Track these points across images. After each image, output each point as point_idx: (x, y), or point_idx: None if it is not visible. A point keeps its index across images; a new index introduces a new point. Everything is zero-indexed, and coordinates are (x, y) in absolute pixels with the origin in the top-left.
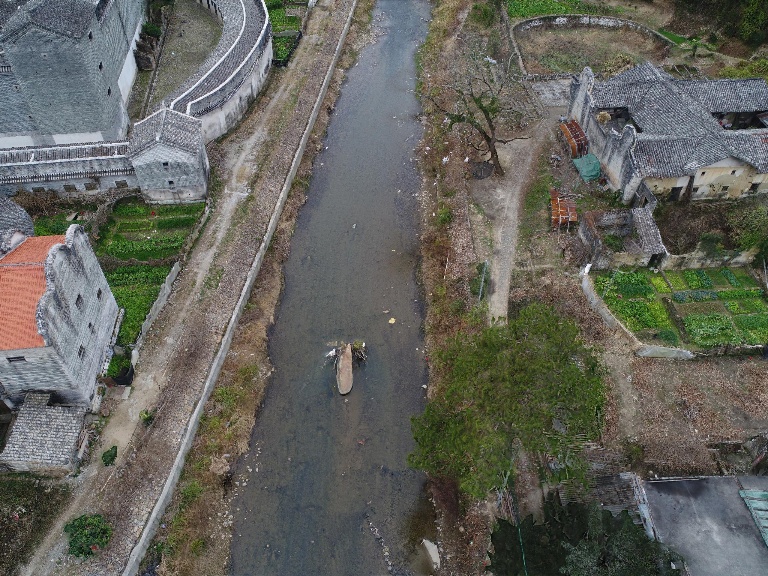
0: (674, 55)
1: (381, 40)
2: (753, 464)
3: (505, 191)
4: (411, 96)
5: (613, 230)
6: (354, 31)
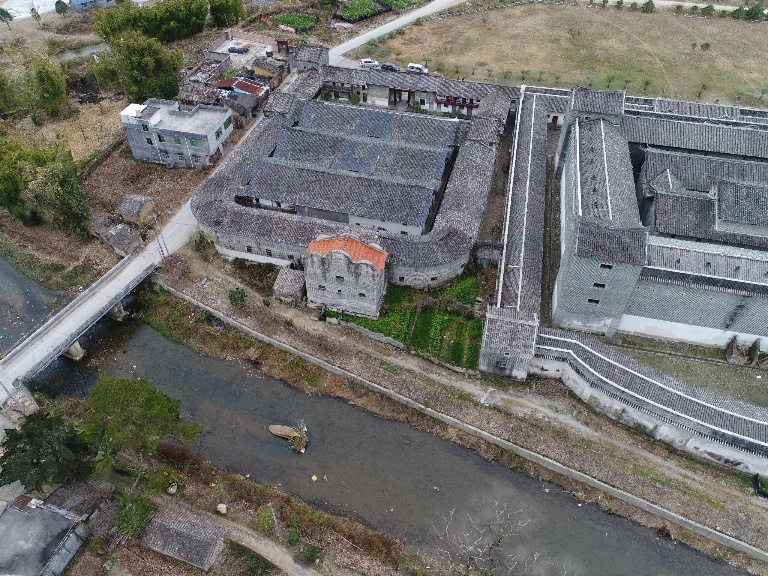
0: None
1: None
2: None
3: None
4: None
5: None
6: None
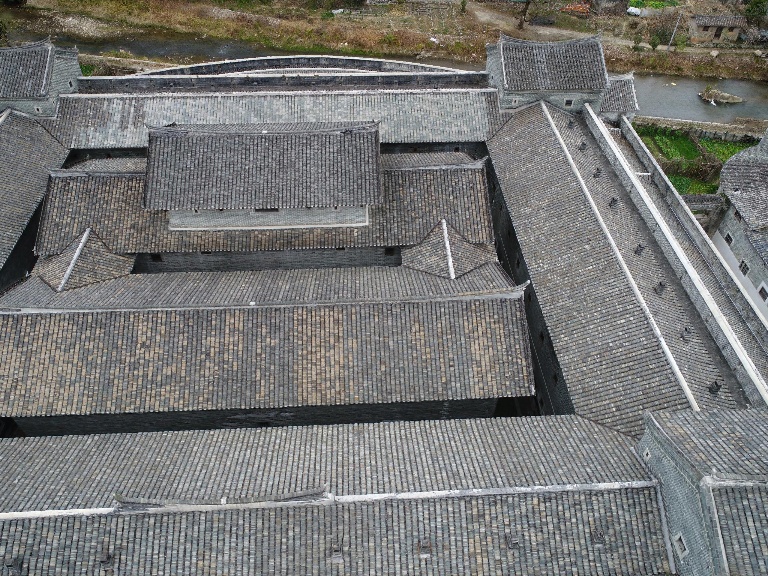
0: None
1: None
2: (738, 4)
3: (540, 30)
4: None
5: None
6: None
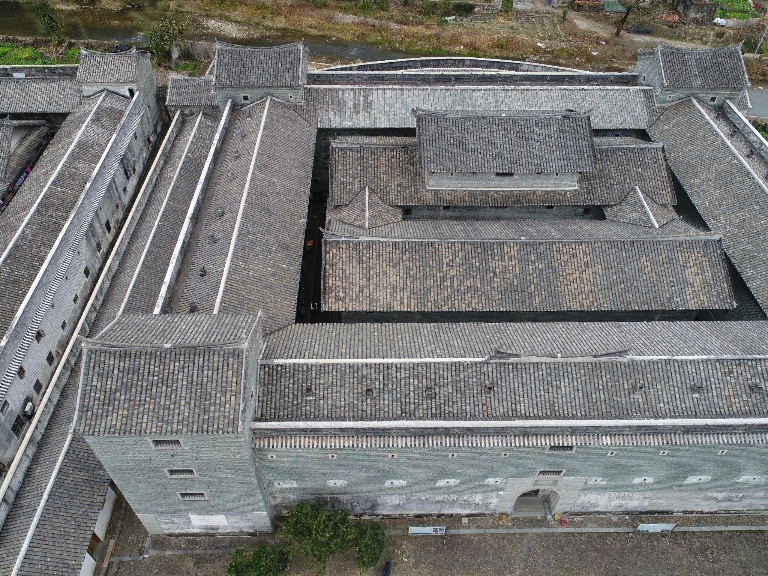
0: None
1: None
2: None
3: (635, 38)
4: None
5: None
6: None
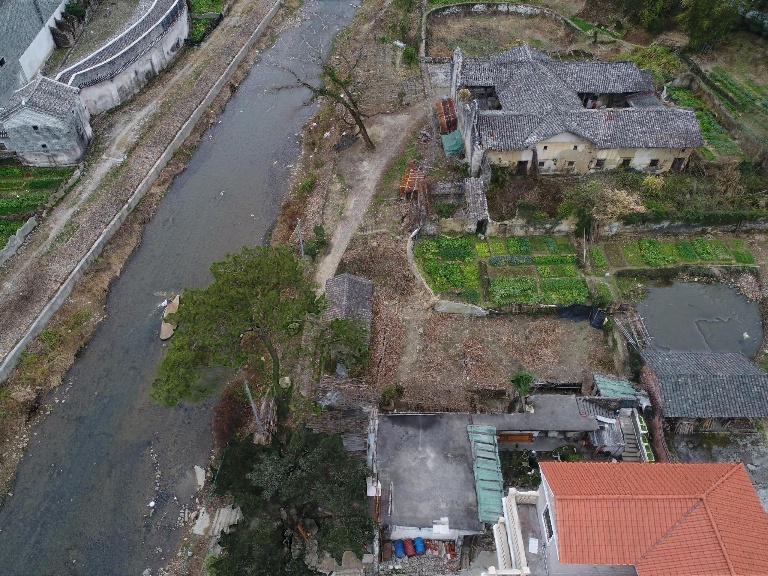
0: (579, 42)
1: (305, 24)
2: None
3: (371, 164)
4: (317, 76)
5: (451, 199)
6: (280, 15)
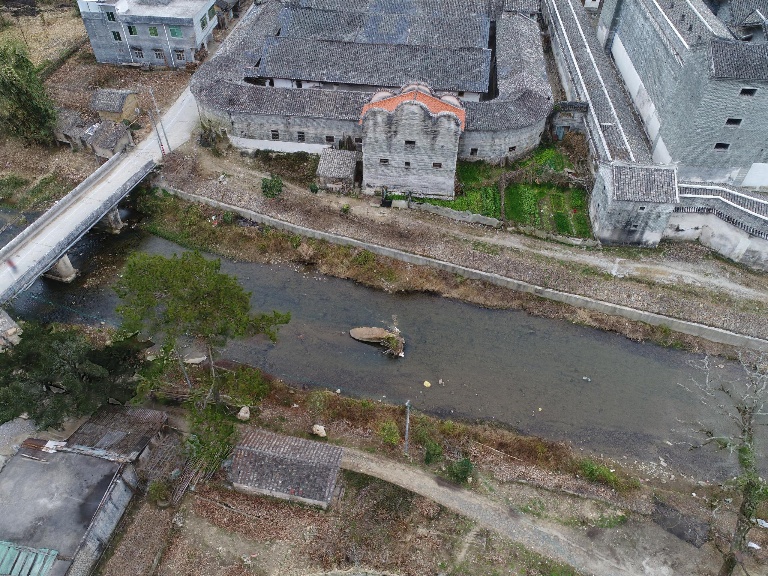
0: None
1: None
2: None
3: None
4: None
5: None
6: None
